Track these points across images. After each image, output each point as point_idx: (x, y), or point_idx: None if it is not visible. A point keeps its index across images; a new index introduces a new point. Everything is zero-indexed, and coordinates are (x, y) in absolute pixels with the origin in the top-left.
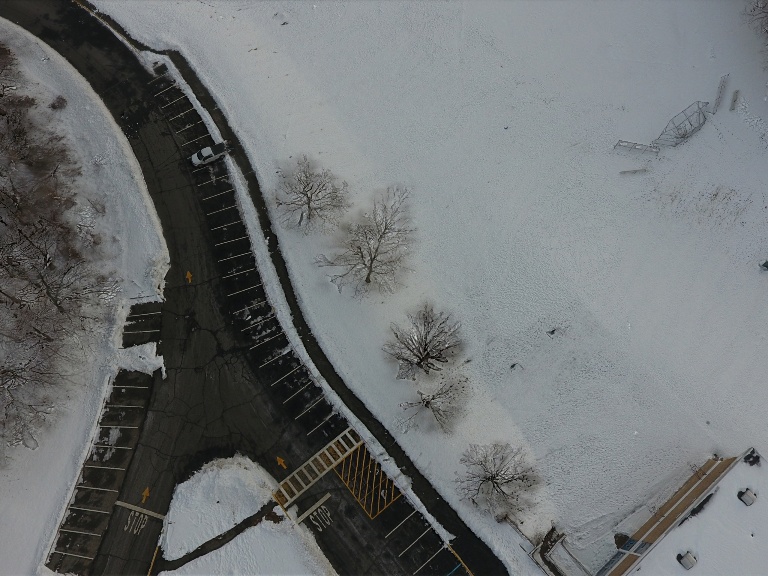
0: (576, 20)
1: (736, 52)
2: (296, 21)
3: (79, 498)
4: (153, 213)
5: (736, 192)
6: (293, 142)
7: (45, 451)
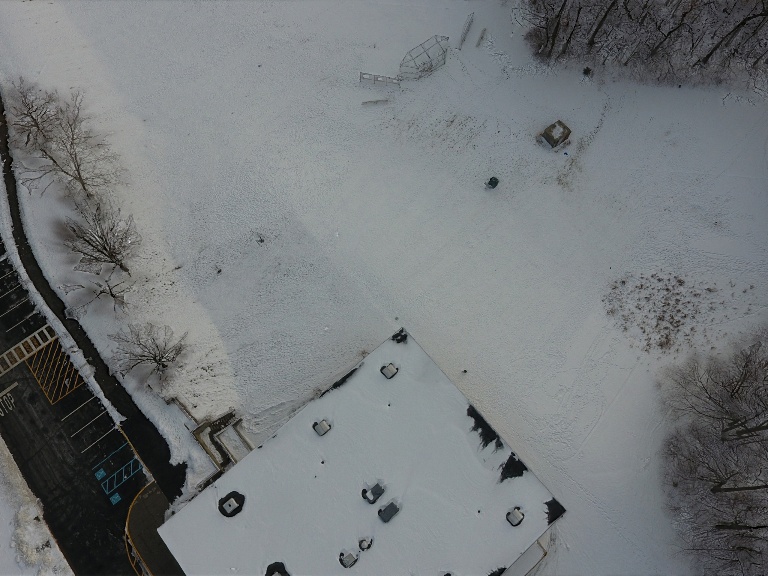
0: None
1: None
2: None
3: None
4: None
5: (472, 119)
6: (46, 78)
7: None
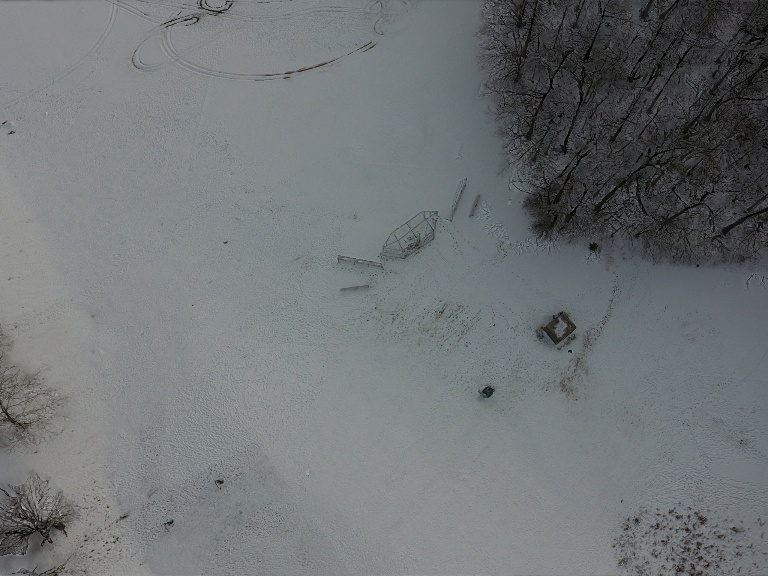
0: (320, 121)
1: (480, 153)
2: (24, 130)
3: None
4: None
5: (464, 308)
6: None
7: None
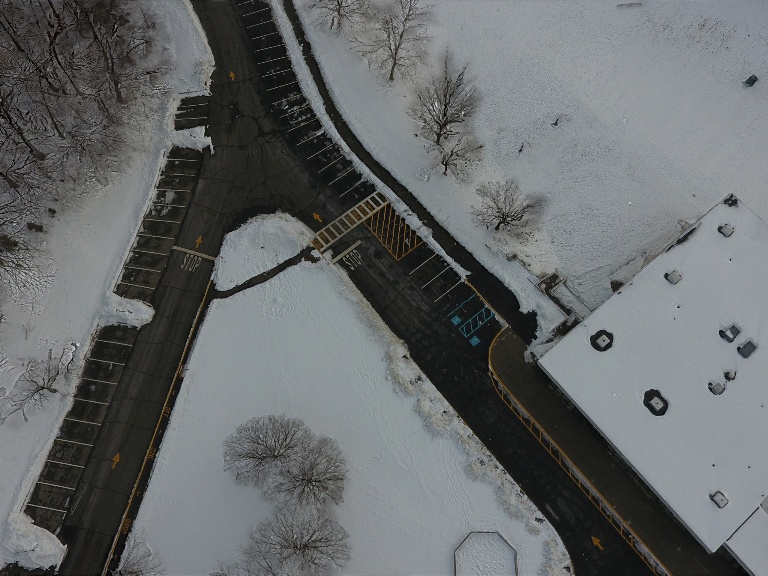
0: None
1: None
2: None
3: (141, 243)
4: (199, 26)
5: (722, 23)
6: None
7: (110, 205)
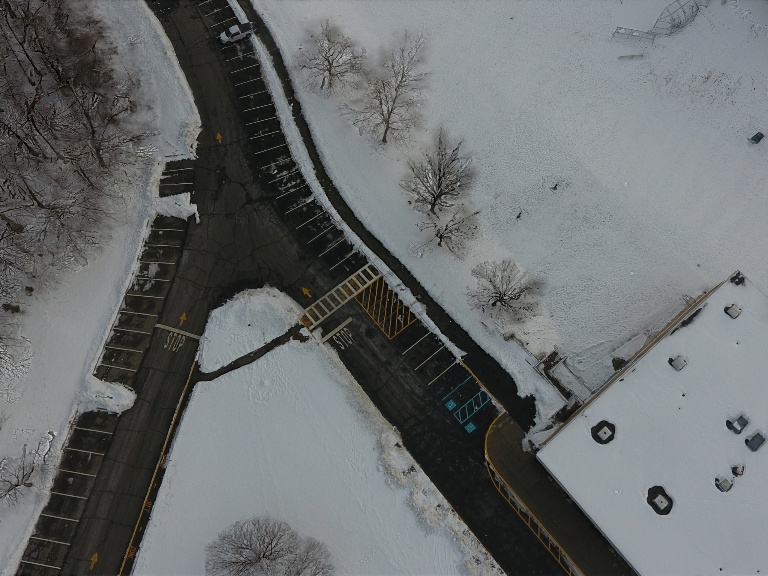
0: None
1: None
2: None
3: (122, 321)
4: (185, 84)
5: (727, 75)
6: (314, 24)
7: (91, 280)
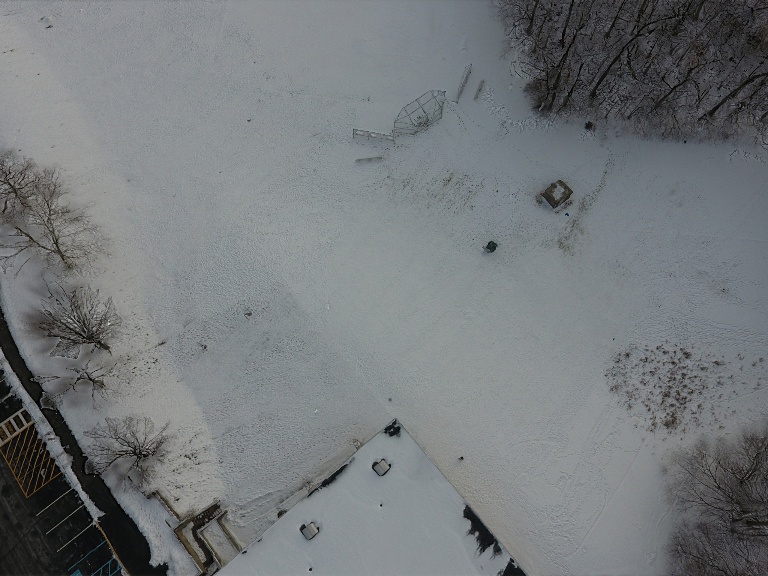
0: (335, 17)
1: (484, 43)
2: (61, 24)
3: None
4: None
5: (469, 177)
6: (26, 136)
7: None
